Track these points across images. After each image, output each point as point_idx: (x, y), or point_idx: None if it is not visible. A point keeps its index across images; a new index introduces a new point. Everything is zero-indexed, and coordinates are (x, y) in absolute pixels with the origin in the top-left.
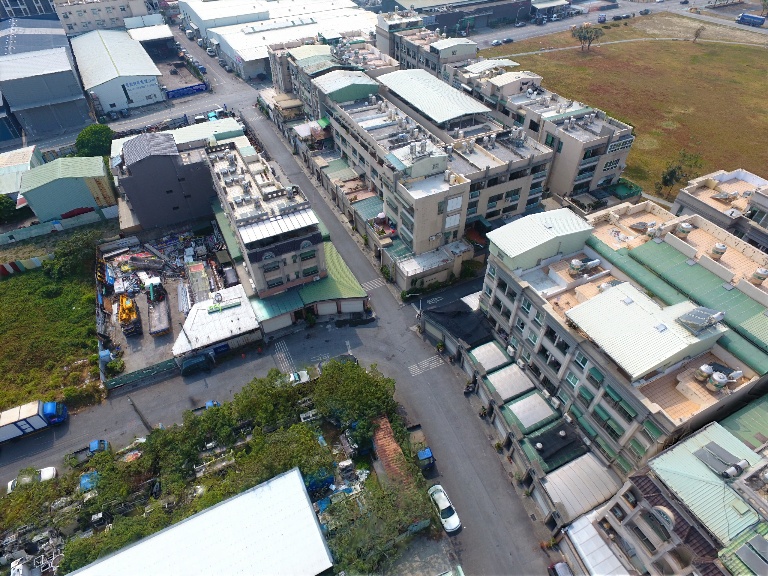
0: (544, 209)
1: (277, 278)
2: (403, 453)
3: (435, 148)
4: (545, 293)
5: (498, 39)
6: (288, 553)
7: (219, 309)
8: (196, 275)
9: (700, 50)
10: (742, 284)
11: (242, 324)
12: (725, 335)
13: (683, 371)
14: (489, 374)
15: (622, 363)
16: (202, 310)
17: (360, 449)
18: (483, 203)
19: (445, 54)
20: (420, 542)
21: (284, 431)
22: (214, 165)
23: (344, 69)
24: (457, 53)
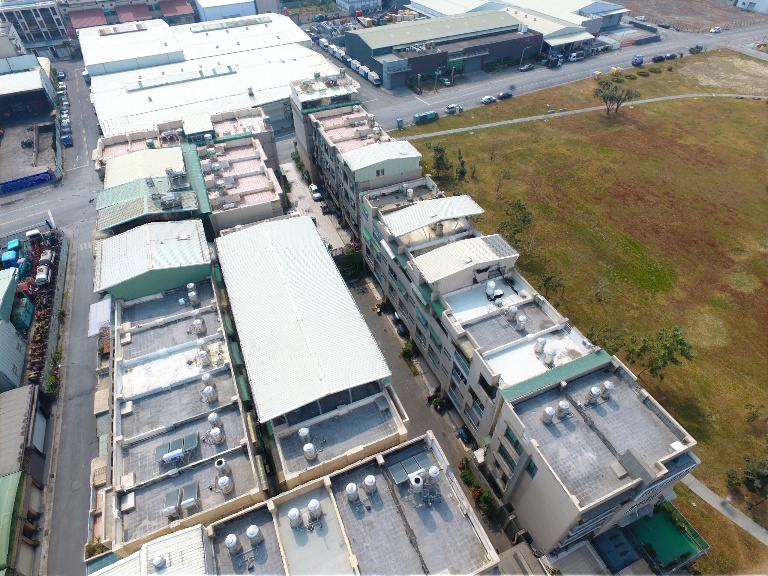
0: None
1: None
2: None
3: (194, 569)
4: None
5: (492, 92)
6: None
7: None
8: None
9: None
10: None
11: None
12: None
13: None
14: None
15: None
16: None
17: None
18: None
19: (364, 175)
20: None
21: None
22: None
23: None
24: (386, 172)
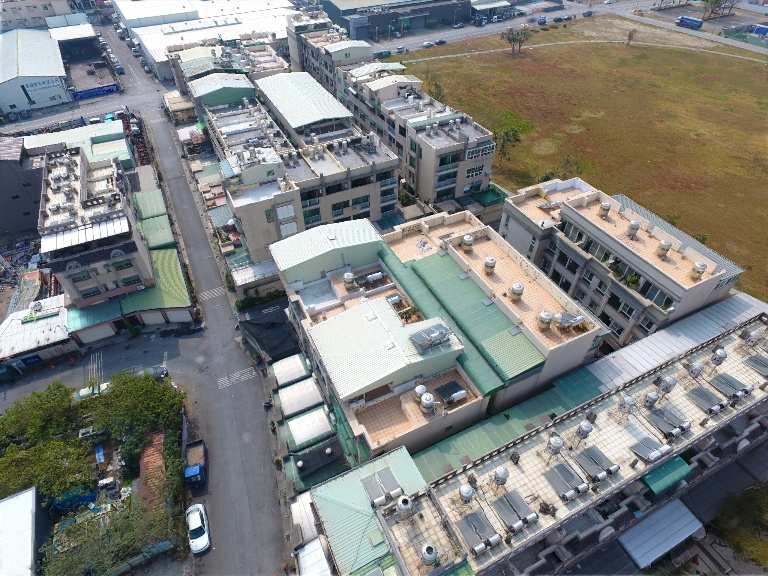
0: (404, 216)
1: (92, 288)
2: (165, 471)
3: (273, 154)
4: (311, 307)
5: (431, 40)
6: None
7: (33, 319)
8: (29, 283)
9: (631, 53)
10: (497, 300)
11: (52, 335)
12: (465, 353)
13: (409, 391)
14: (283, 388)
15: (336, 383)
16: (17, 320)
17: (129, 466)
18: (326, 210)
19: (337, 57)
20: (162, 564)
21: (40, 448)
22: (52, 171)
23: (228, 72)
24: (351, 56)
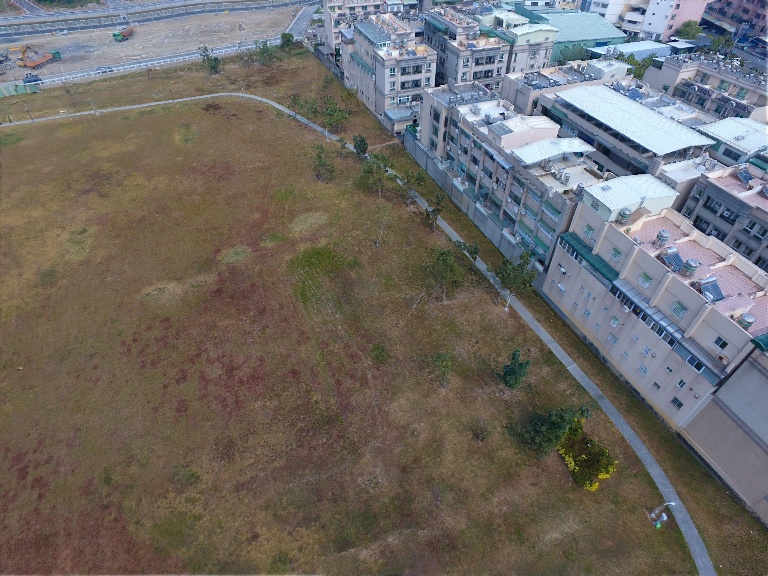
0: None
1: None
2: None
3: (599, 66)
4: None
5: None
6: (600, 49)
7: None
8: None
9: None
10: None
11: None
12: None
13: None
14: None
15: None
16: None
17: None
18: None
19: None
20: None
21: None
22: None
23: None
24: None
